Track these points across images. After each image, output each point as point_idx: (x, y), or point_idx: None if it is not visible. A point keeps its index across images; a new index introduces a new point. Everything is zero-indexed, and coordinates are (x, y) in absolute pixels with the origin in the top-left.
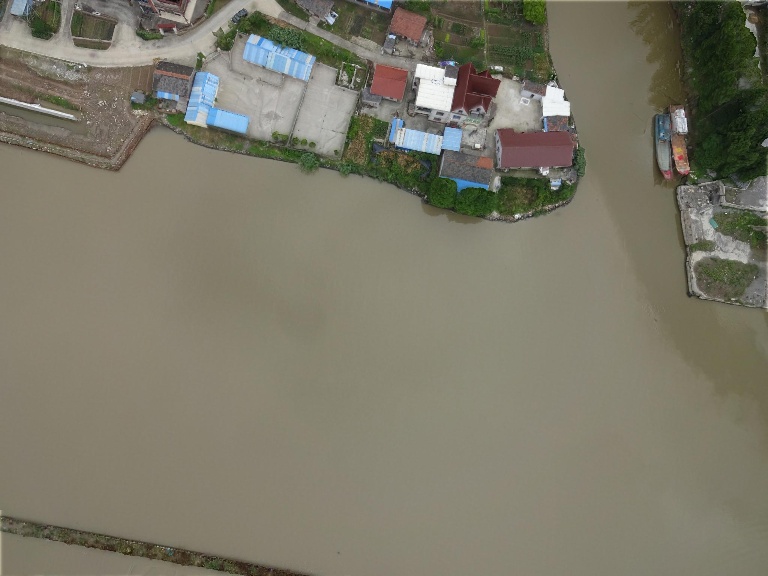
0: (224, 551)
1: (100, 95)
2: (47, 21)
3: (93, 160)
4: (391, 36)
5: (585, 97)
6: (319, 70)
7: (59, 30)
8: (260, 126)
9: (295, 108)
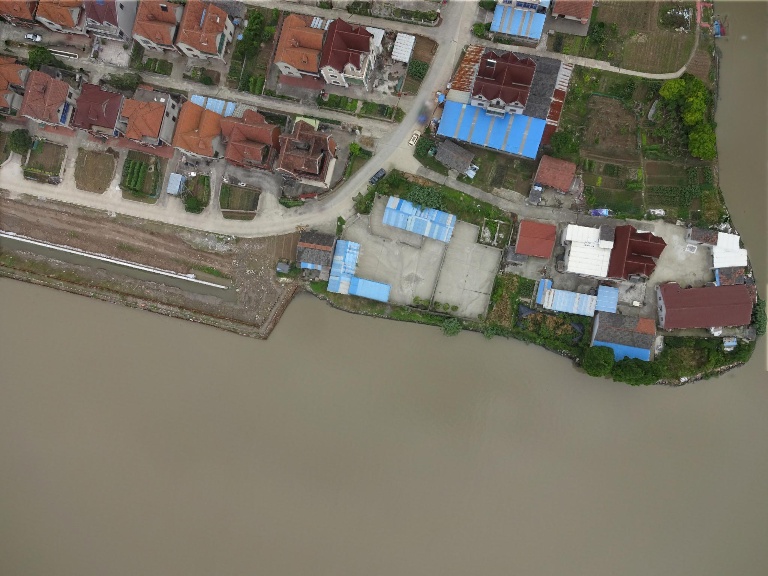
0: None
1: (248, 264)
2: (198, 195)
3: (244, 330)
4: (537, 188)
5: (764, 233)
6: (460, 227)
7: (209, 203)
8: (401, 289)
9: (436, 269)
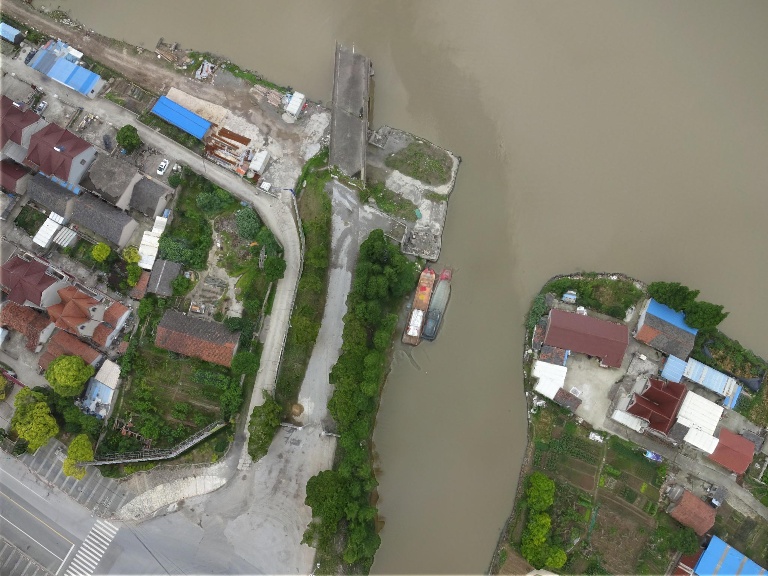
0: None
1: None
2: None
3: None
4: (717, 503)
5: (494, 385)
6: None
7: None
8: None
9: None
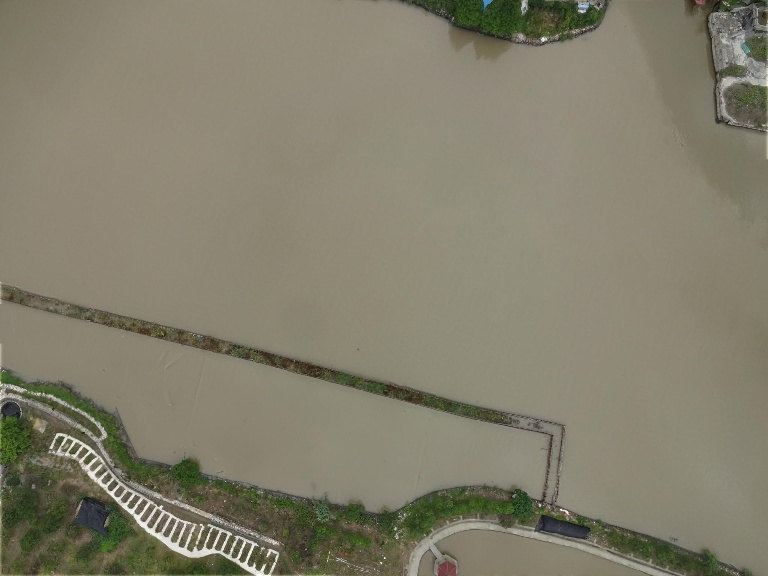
0: (250, 342)
1: None
2: None
3: None
4: None
5: None
6: None
7: None
8: None
9: None
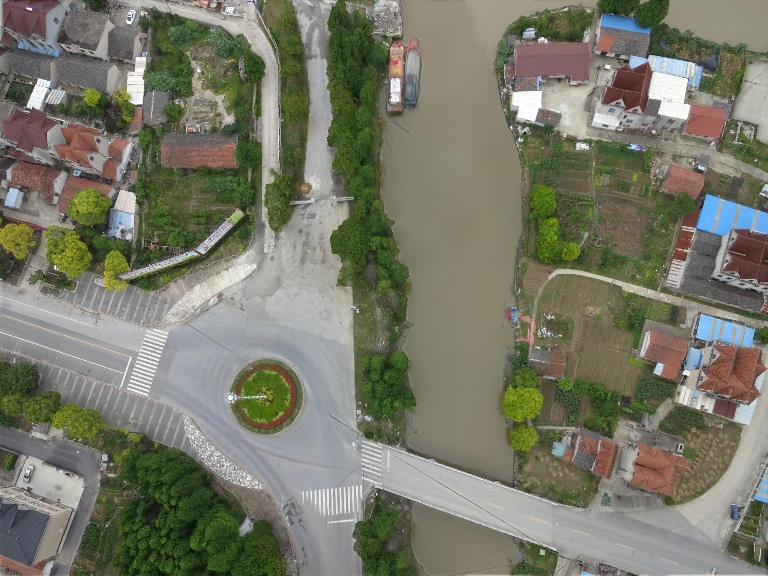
0: None
1: None
2: None
3: None
4: (703, 169)
5: (480, 133)
6: None
7: None
8: None
9: None
